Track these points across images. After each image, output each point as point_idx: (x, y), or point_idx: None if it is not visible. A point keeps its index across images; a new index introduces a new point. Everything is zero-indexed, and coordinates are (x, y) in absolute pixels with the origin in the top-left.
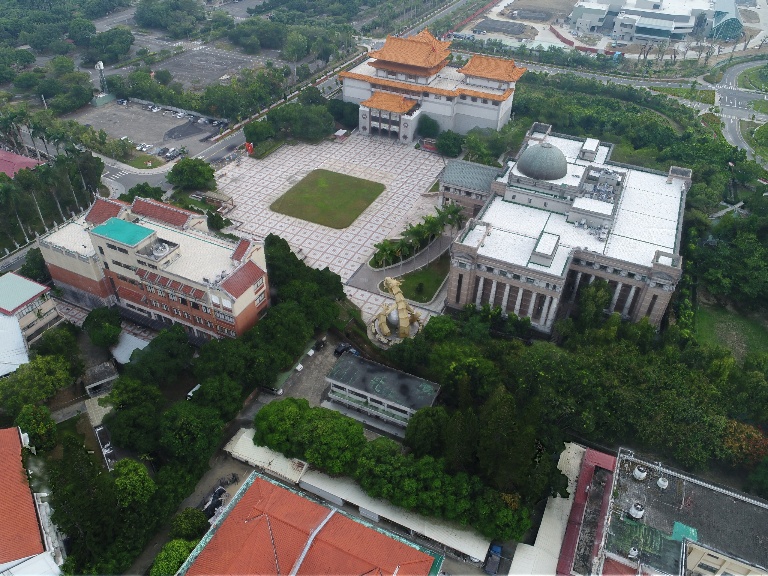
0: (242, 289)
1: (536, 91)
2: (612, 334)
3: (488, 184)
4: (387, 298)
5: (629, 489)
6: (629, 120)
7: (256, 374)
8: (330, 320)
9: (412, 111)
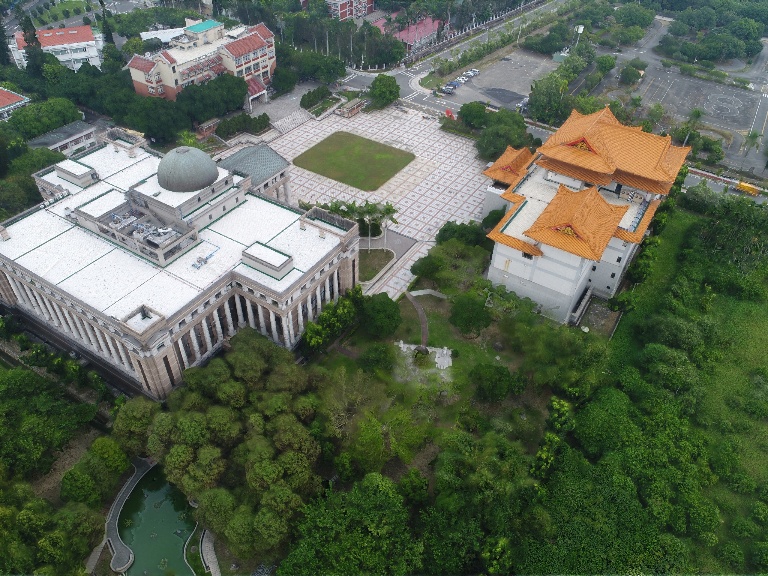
0: (135, 66)
1: None
2: None
3: None
4: None
5: None
6: (502, 448)
7: None
8: None
9: None
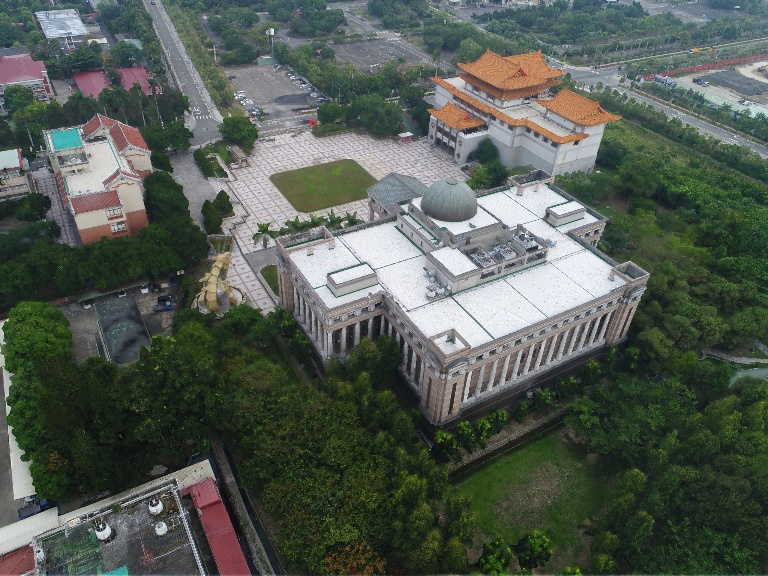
0: (88, 208)
1: (686, 156)
2: (342, 391)
3: None
4: (257, 279)
5: (135, 514)
6: (718, 210)
7: (57, 279)
8: (163, 268)
9: (476, 131)
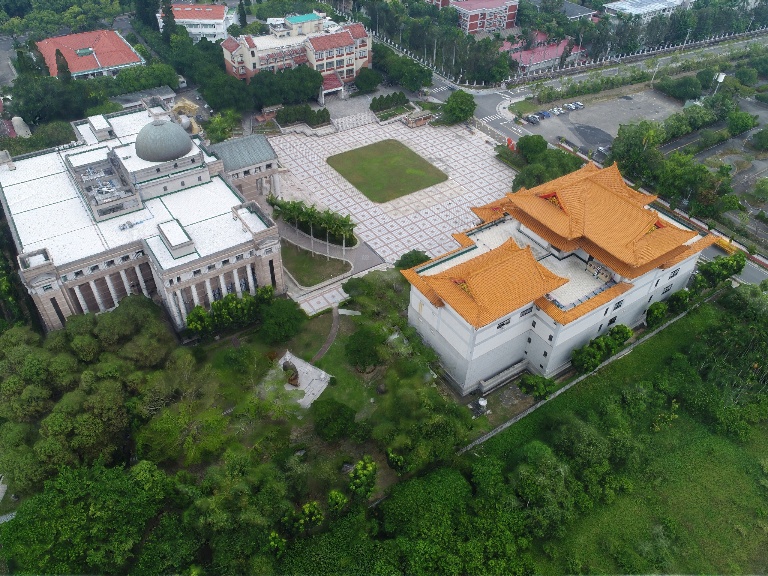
0: None
1: None
2: None
3: (210, 146)
4: None
5: None
6: (264, 484)
7: None
8: None
9: None
